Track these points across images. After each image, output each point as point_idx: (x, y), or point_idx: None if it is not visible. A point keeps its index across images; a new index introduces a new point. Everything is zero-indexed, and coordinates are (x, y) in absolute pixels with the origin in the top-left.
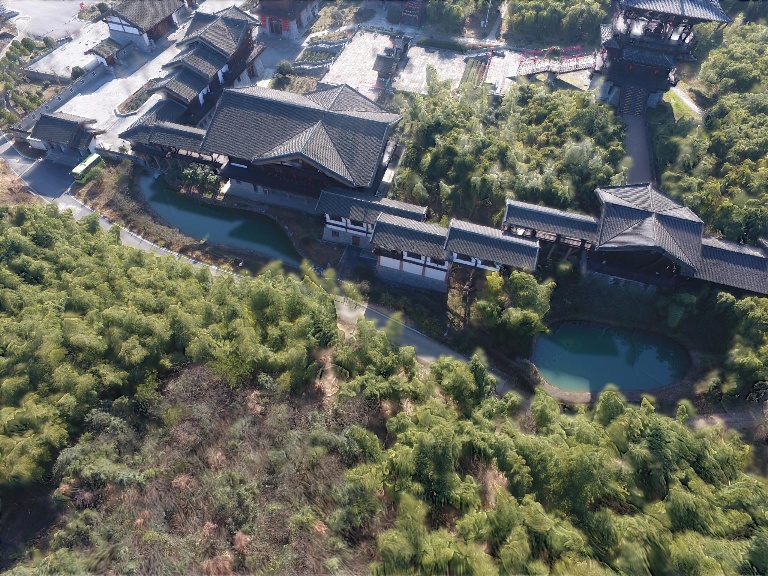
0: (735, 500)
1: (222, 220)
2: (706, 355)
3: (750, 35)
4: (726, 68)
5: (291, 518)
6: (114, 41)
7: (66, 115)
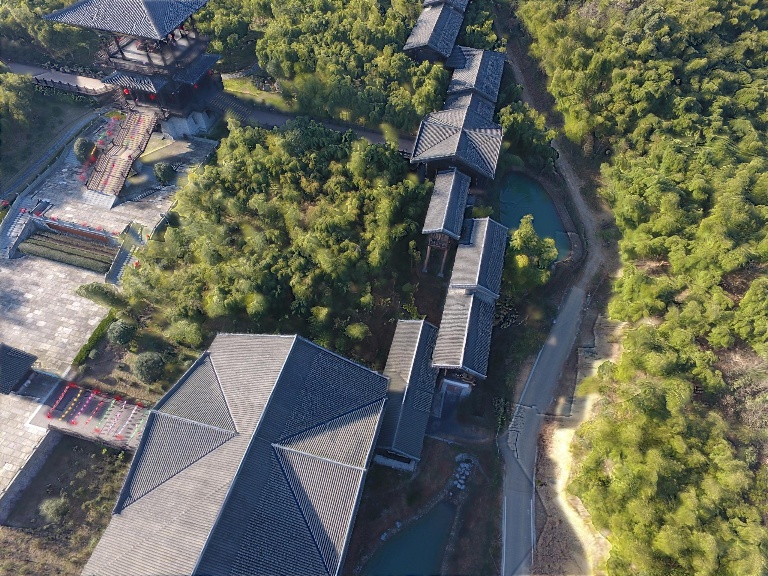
0: (685, 163)
1: None
2: (530, 159)
3: None
4: (217, 30)
5: None
6: None
7: None
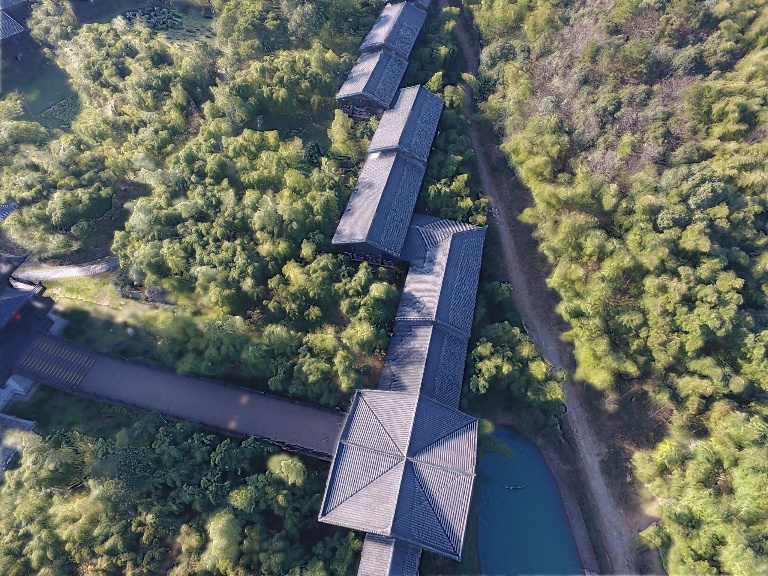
0: None
1: None
2: (523, 419)
3: None
4: (53, 220)
5: None
6: None
7: None
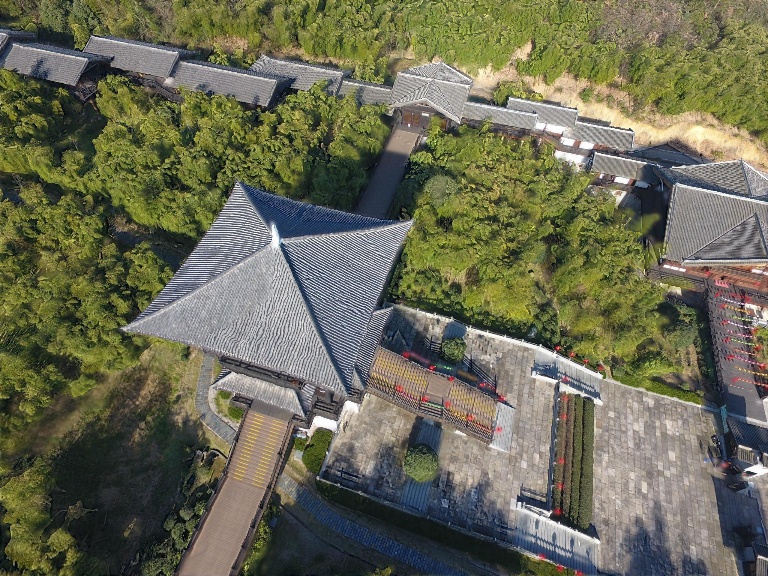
0: None
1: None
2: None
3: (4, 392)
4: None
5: (619, 1)
6: None
7: None
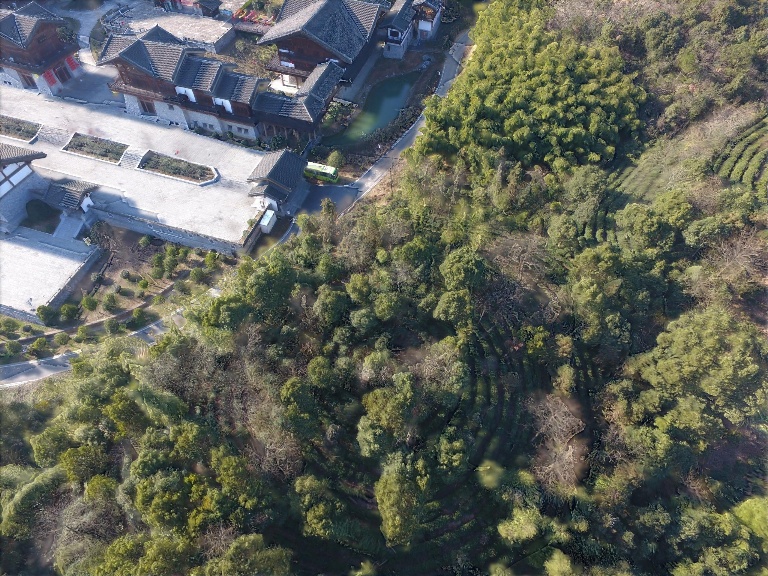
0: None
1: (374, 110)
2: None
3: None
4: None
5: None
6: (58, 181)
7: (258, 171)
